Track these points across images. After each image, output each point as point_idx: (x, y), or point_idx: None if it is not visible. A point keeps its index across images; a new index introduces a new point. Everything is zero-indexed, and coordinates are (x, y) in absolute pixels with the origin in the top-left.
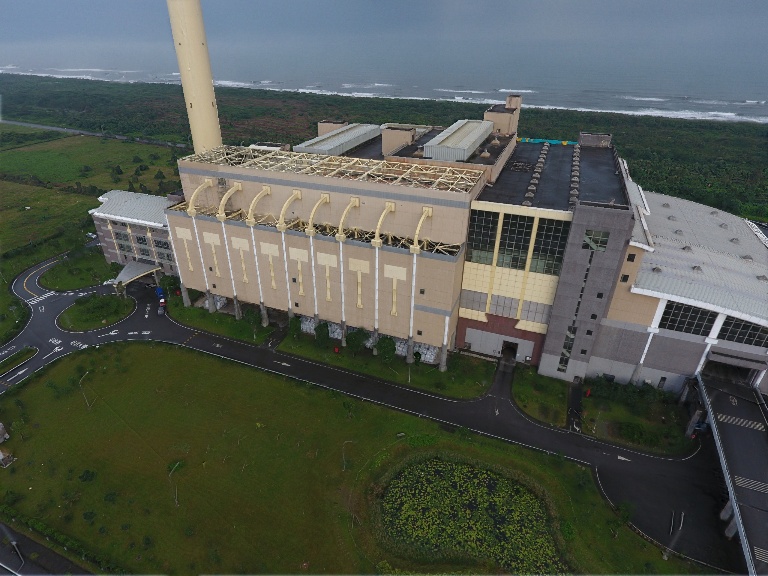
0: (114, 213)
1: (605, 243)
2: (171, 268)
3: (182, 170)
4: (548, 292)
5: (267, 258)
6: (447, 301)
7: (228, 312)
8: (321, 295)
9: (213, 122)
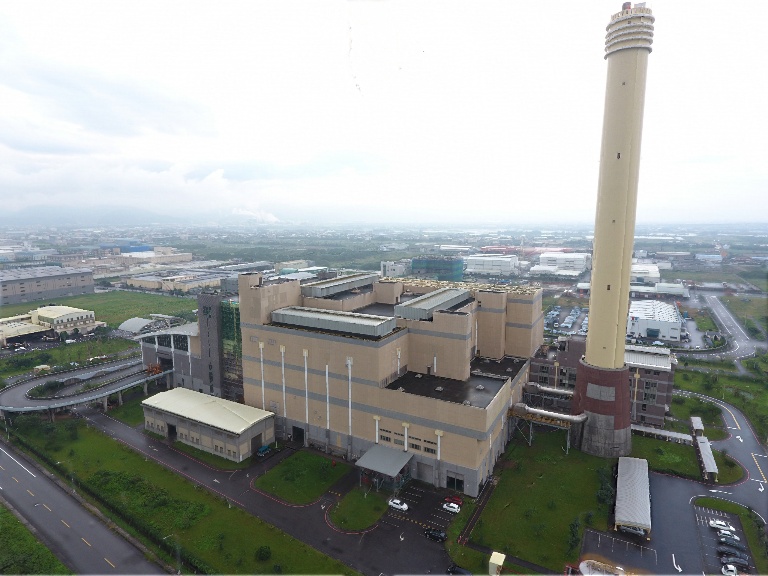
0: None
1: None
2: None
3: None
4: None
5: None
6: None
7: None
8: None
9: None
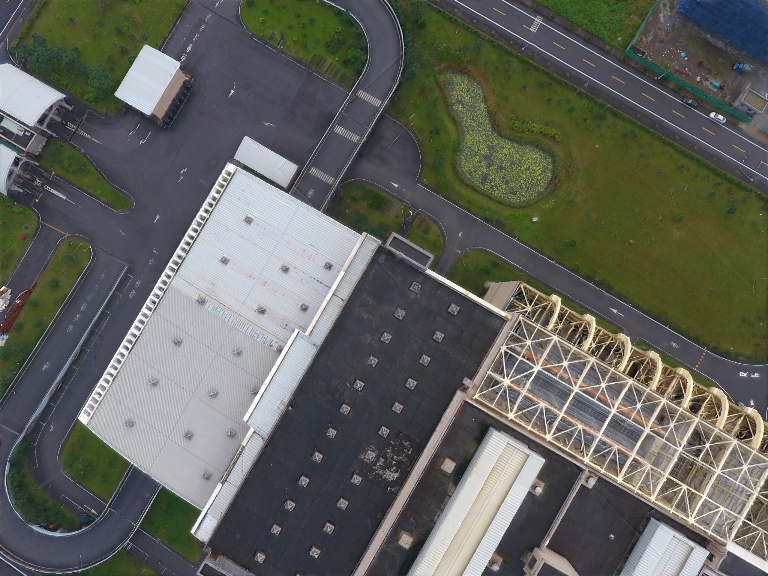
0: None
1: None
2: None
3: None
4: None
5: None
6: None
7: None
8: None
9: None
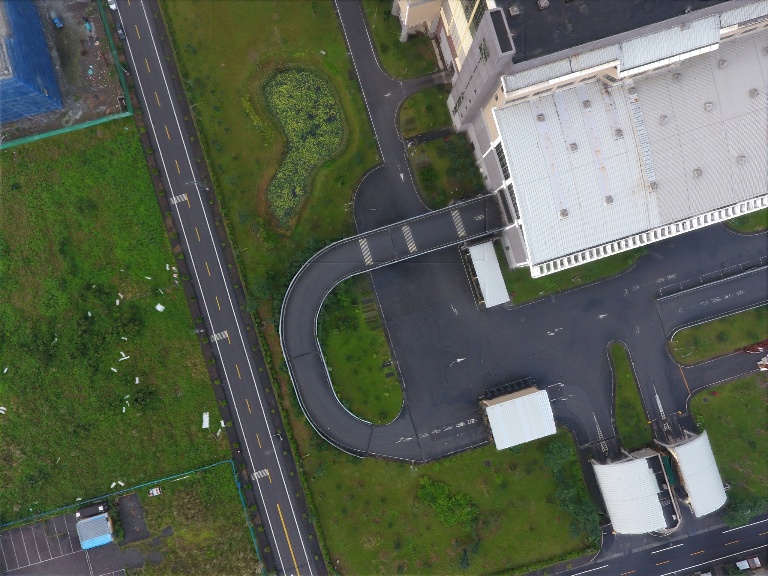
0: None
1: (486, 60)
2: None
3: None
4: None
5: None
6: None
7: None
8: None
9: None
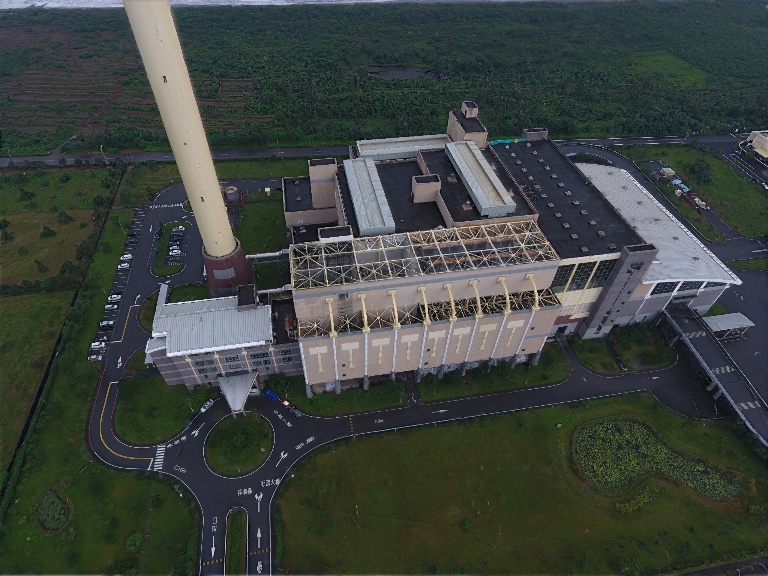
0: (193, 347)
1: (640, 268)
2: (267, 369)
3: (297, 297)
4: (595, 296)
5: (406, 344)
6: (549, 329)
7: (351, 386)
8: (450, 352)
9: (223, 206)
